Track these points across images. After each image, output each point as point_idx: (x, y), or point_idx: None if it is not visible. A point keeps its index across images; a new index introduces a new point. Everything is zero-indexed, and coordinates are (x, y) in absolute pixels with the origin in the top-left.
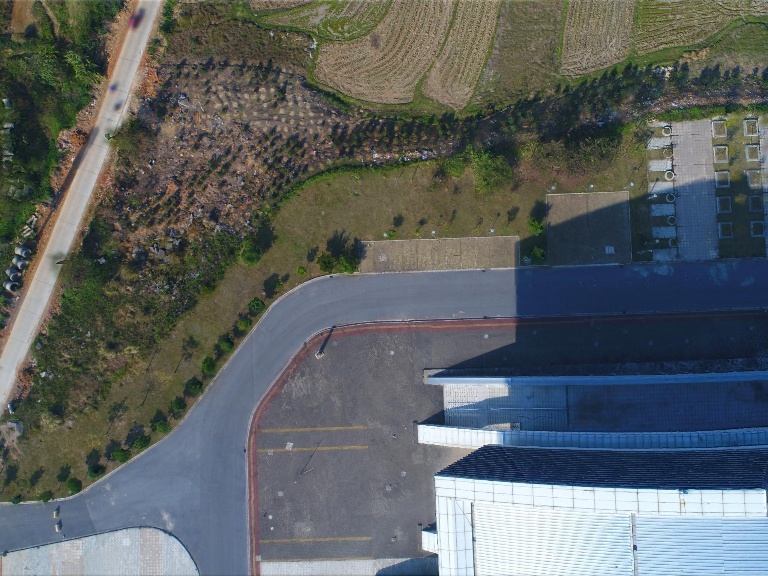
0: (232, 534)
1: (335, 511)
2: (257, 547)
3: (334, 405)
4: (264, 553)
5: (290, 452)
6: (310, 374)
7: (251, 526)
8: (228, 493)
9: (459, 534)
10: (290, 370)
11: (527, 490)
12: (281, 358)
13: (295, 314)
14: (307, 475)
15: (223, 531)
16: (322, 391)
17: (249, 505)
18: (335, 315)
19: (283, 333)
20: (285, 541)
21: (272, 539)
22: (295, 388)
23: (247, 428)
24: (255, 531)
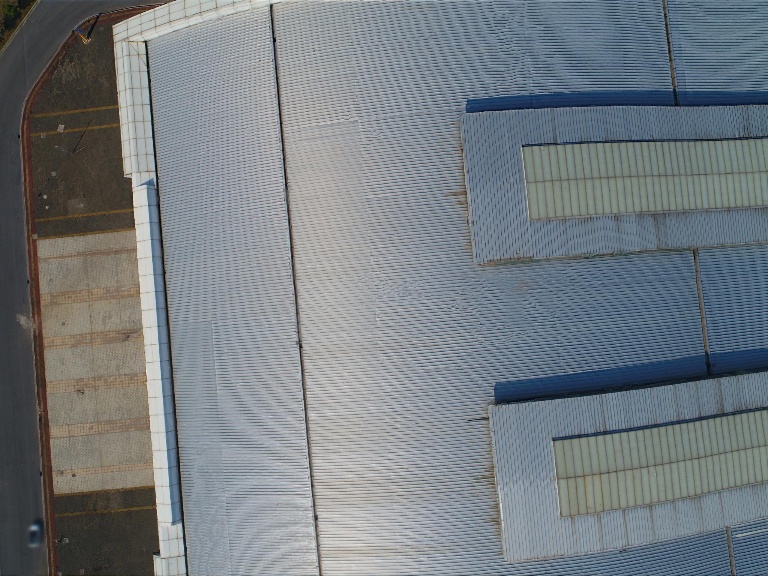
0: (9, 216)
1: (106, 186)
2: (33, 226)
3: (102, 86)
4: (40, 231)
5: (62, 134)
6: (78, 59)
7: (27, 207)
8: (4, 178)
9: (134, 73)
10: (59, 57)
11: (180, 5)
12: (51, 47)
13: (63, 4)
14: (79, 154)
15: (0, 214)
16: (90, 74)
17: (24, 187)
18: (101, 3)
19: (52, 23)
20: (60, 218)
21: (47, 217)
22: (65, 73)
23: (20, 115)
24: (31, 211)
